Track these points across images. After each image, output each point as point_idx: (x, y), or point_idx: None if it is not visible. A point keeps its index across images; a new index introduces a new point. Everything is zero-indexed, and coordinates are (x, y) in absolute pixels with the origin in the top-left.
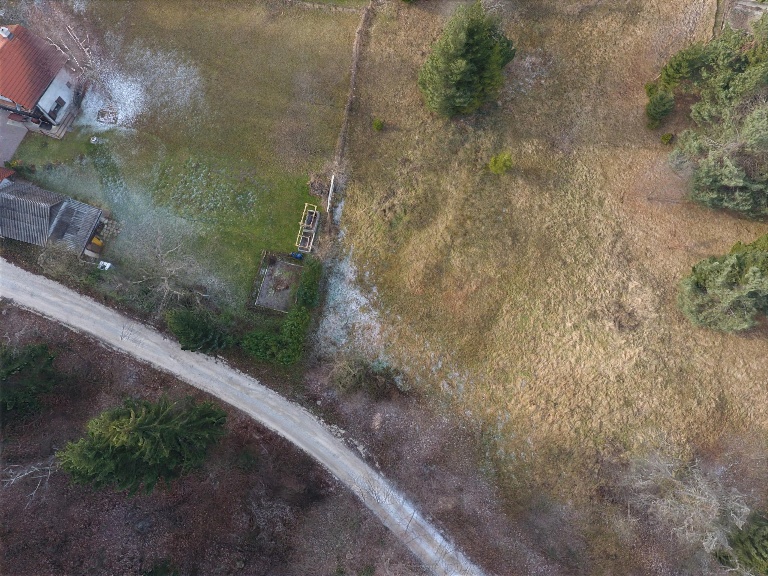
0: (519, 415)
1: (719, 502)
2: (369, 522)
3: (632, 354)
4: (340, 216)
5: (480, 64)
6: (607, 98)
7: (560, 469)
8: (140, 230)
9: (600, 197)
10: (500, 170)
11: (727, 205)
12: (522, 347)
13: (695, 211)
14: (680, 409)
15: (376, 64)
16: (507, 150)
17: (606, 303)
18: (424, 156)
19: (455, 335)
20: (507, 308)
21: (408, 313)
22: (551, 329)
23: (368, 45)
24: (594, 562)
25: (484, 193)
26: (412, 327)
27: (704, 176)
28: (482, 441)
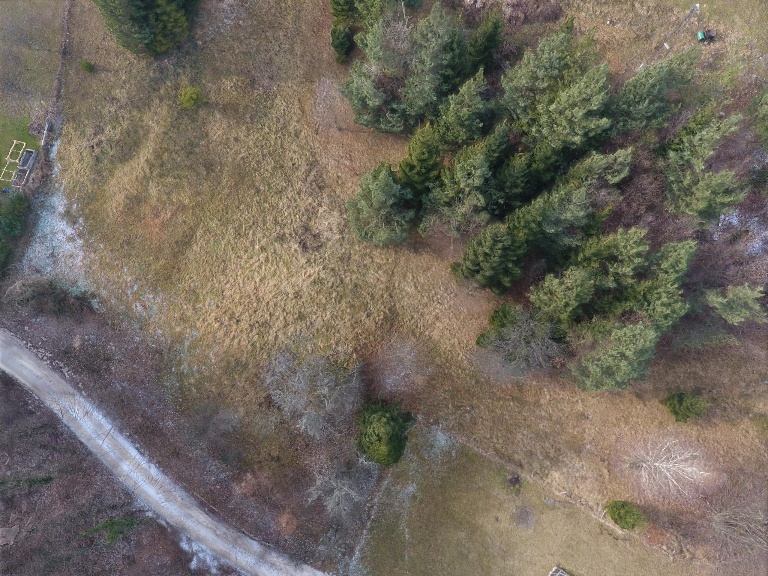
0: (205, 332)
1: (313, 388)
2: (65, 437)
3: (312, 272)
4: (55, 154)
5: (149, 0)
6: (302, 36)
7: (235, 380)
8: None
9: (297, 129)
10: (188, 103)
11: (383, 127)
12: (213, 269)
13: (379, 139)
14: (350, 321)
15: (86, 9)
16: (205, 86)
17: (294, 227)
18: (130, 94)
19: (152, 260)
20: (200, 234)
21: (110, 241)
22: (240, 252)
23: None
24: (261, 465)
25: (182, 127)
26: (112, 254)
27: (354, 99)
28: (169, 357)
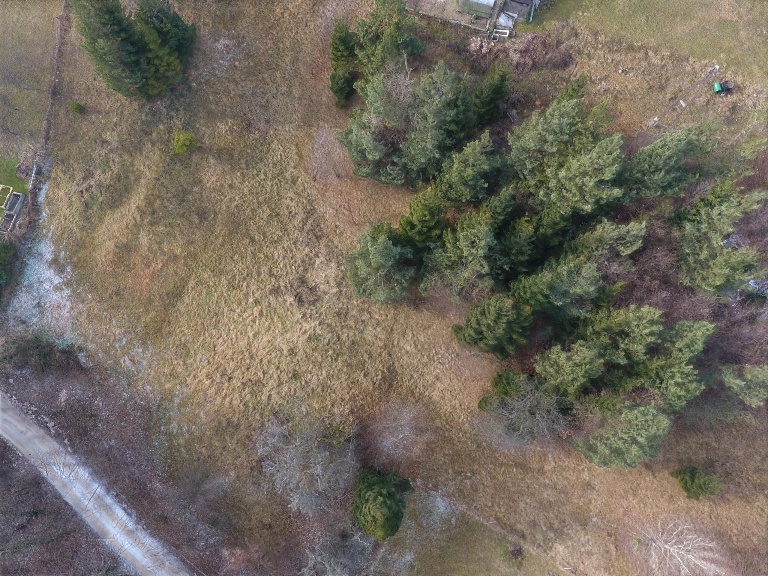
0: (196, 389)
1: (305, 465)
2: (49, 497)
3: (307, 328)
4: (43, 198)
5: (140, 45)
6: (301, 79)
7: (226, 441)
8: None
9: (294, 176)
10: (181, 149)
11: (383, 179)
12: (205, 323)
13: (379, 188)
14: (346, 381)
15: (76, 48)
16: (199, 130)
17: (290, 279)
18: (121, 138)
19: (141, 312)
20: (192, 285)
21: (98, 291)
22: (234, 305)
23: (69, 30)
24: (252, 532)
25: (174, 173)
26: (101, 305)
27: (353, 151)
28: (158, 415)
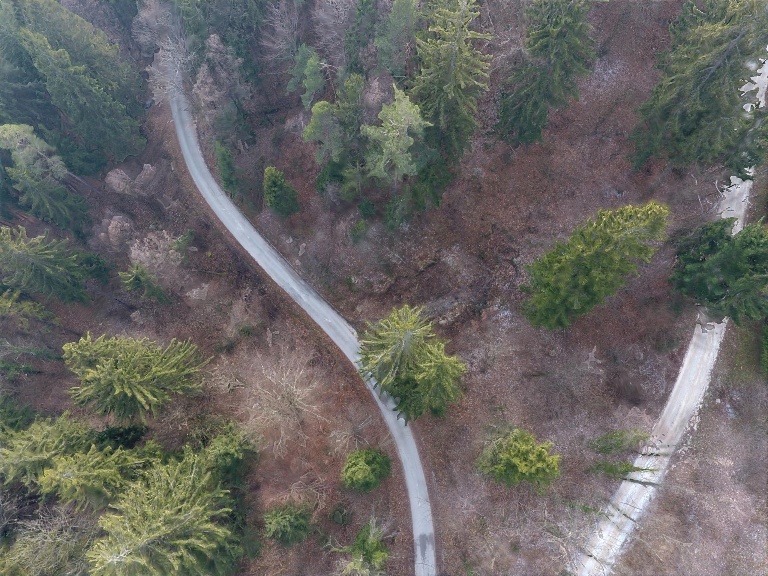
0: None
1: None
2: (622, 464)
3: None
4: None
5: None
6: None
7: None
8: None
9: None
10: None
11: None
12: None
13: None
14: None
15: None
16: None
17: None
18: None
19: None
20: None
21: None
22: None
23: None
24: None
25: None
26: None
27: None
28: None
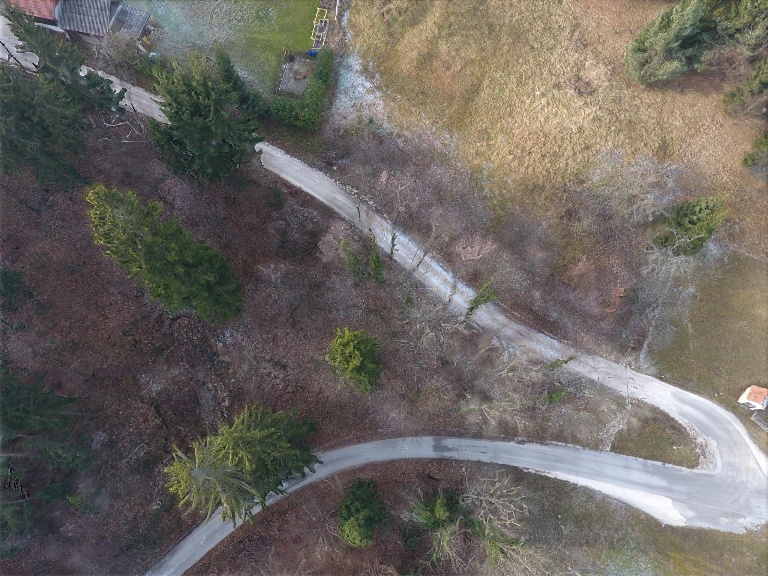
0: (500, 164)
1: (655, 170)
2: (381, 257)
3: (590, 112)
4: (346, 23)
5: None
6: None
7: (535, 199)
8: (181, 35)
9: None
10: None
11: None
12: (500, 113)
13: (636, 2)
14: (630, 149)
15: None
16: None
17: (568, 77)
18: None
19: (445, 106)
20: (487, 83)
21: (406, 92)
22: (523, 97)
23: None
24: (566, 268)
25: None
26: (410, 102)
27: None
28: (471, 185)
